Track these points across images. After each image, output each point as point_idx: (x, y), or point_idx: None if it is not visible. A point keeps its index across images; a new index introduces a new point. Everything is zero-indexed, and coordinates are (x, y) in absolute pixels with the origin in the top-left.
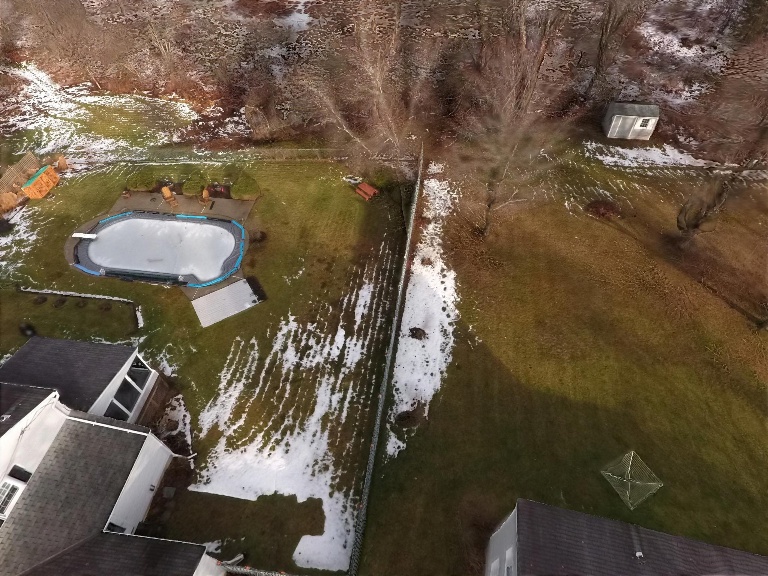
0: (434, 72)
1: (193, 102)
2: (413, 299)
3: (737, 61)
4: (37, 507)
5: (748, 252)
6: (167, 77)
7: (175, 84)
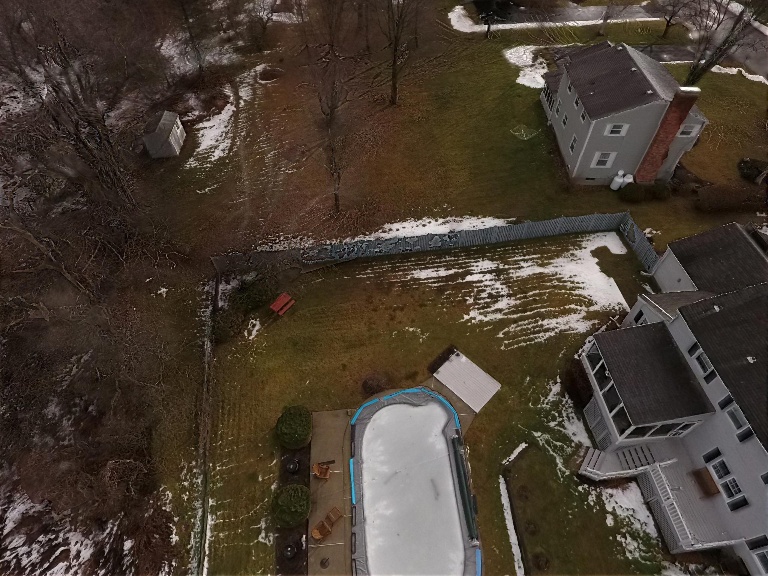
0: None
1: None
2: None
3: None
4: None
5: None
6: None
7: None
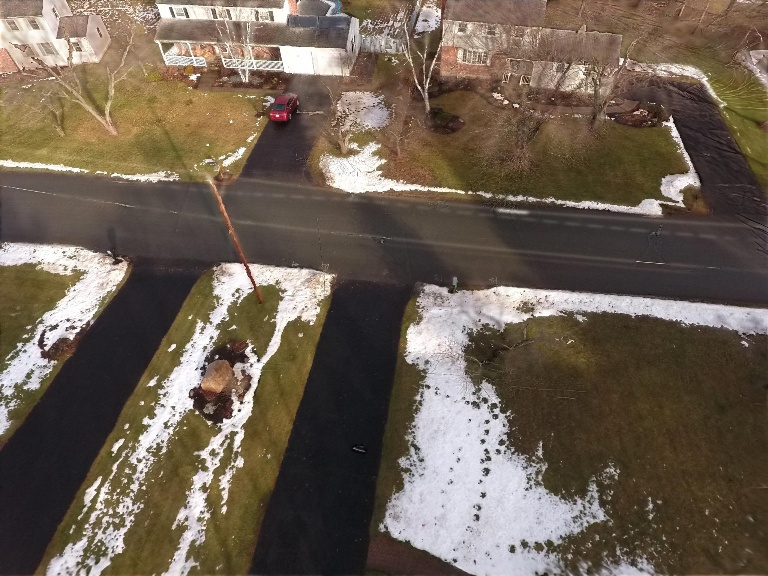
0: None
1: None
2: None
3: None
4: (305, 7)
5: None
6: None
7: None
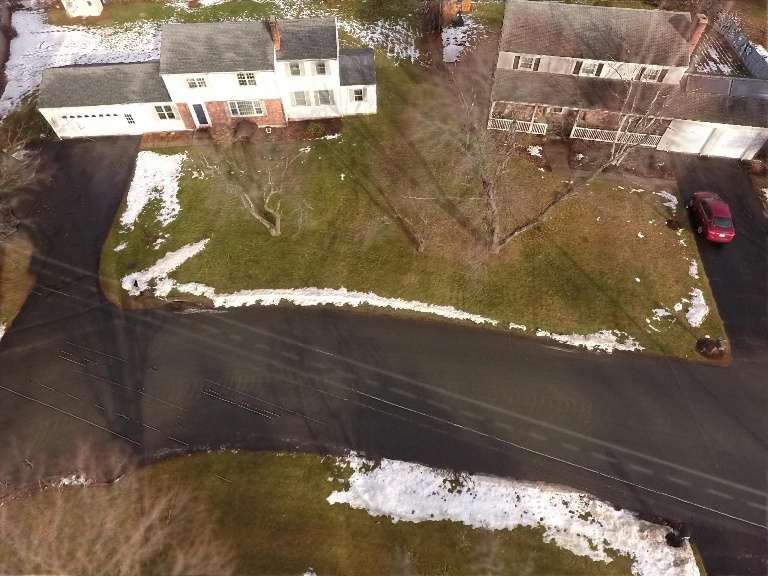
0: None
1: None
2: None
3: None
4: None
5: None
6: None
7: None
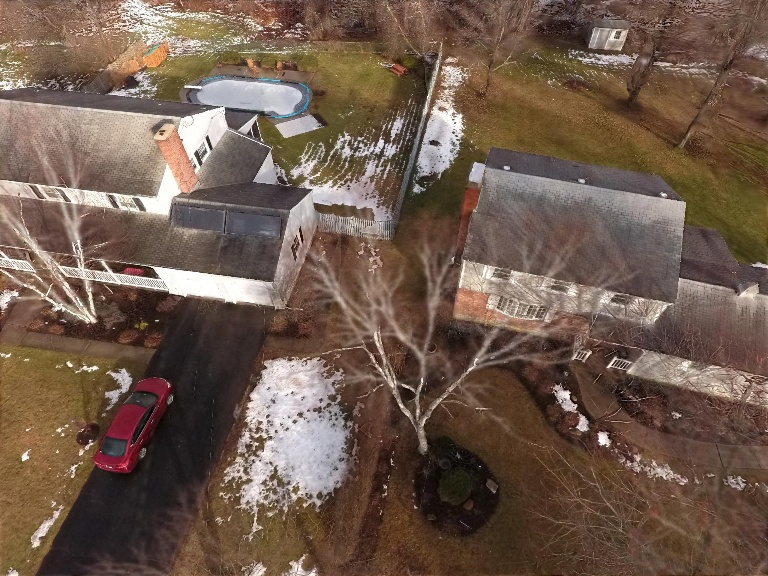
0: (453, 4)
1: (257, 18)
2: (432, 127)
3: (707, 4)
4: (217, 163)
5: (679, 111)
6: (234, 1)
7: (242, 6)
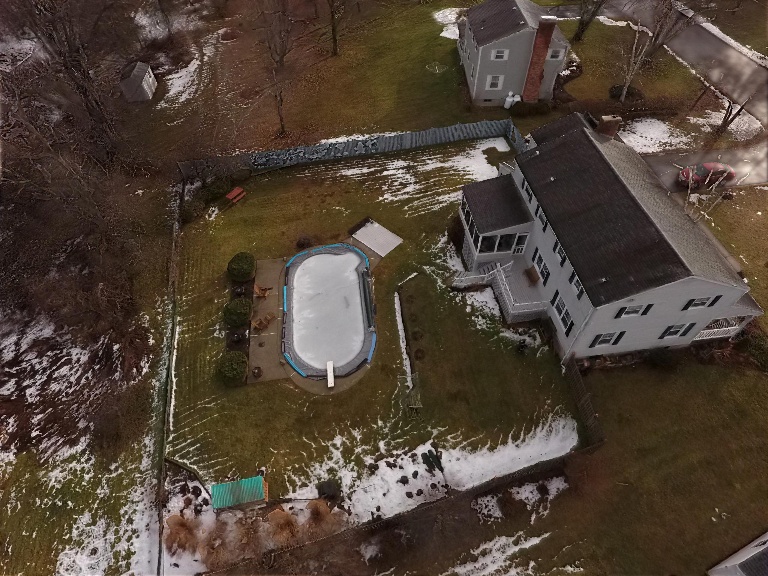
0: None
1: None
2: None
3: None
4: None
5: None
6: None
7: None
